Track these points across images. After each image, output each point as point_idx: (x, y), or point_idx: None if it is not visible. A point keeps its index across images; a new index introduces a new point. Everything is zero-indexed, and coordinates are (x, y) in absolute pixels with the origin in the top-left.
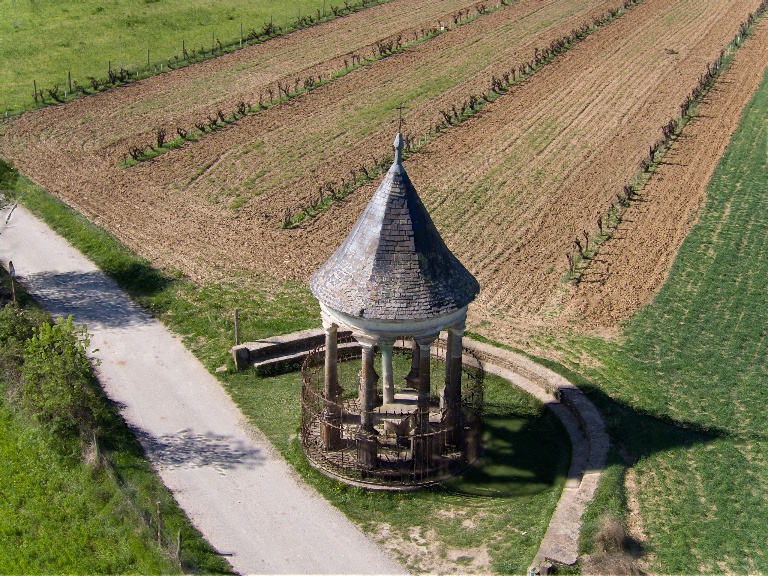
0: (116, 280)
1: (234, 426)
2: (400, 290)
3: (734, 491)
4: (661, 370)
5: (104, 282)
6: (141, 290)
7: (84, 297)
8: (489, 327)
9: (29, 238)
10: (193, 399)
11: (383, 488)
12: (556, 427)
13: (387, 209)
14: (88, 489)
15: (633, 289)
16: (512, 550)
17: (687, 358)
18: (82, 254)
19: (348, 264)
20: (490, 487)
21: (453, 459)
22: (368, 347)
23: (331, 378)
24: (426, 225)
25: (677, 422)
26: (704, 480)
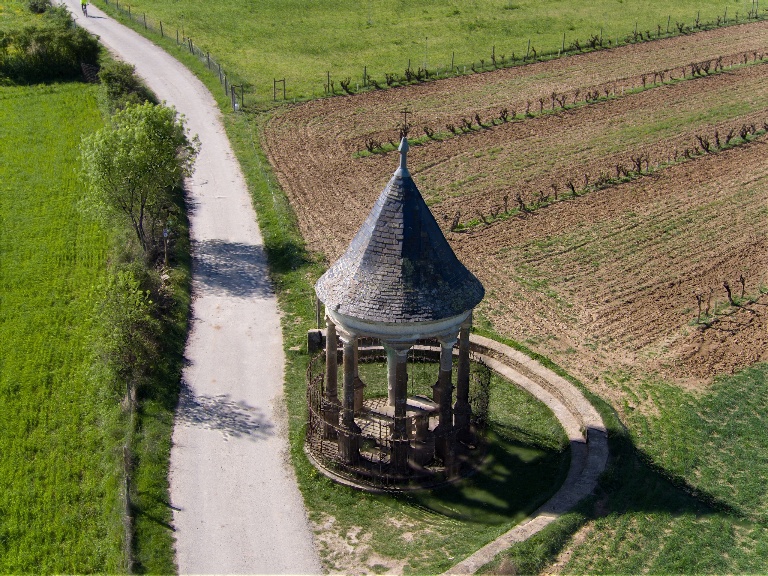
0: (268, 255)
1: (268, 400)
2: (377, 291)
3: (687, 570)
4: (718, 432)
5: (258, 256)
6: (280, 267)
7: (232, 266)
8: (571, 356)
9: (229, 209)
10: (252, 370)
11: (349, 484)
12: (564, 465)
13: (383, 211)
14: (110, 427)
15: (762, 345)
16: (427, 570)
17: (759, 426)
18: (259, 229)
19: (345, 260)
20: (455, 507)
21: (432, 472)
22: (346, 343)
23: (330, 369)
24: (421, 232)
25: (688, 487)
26: (662, 551)
